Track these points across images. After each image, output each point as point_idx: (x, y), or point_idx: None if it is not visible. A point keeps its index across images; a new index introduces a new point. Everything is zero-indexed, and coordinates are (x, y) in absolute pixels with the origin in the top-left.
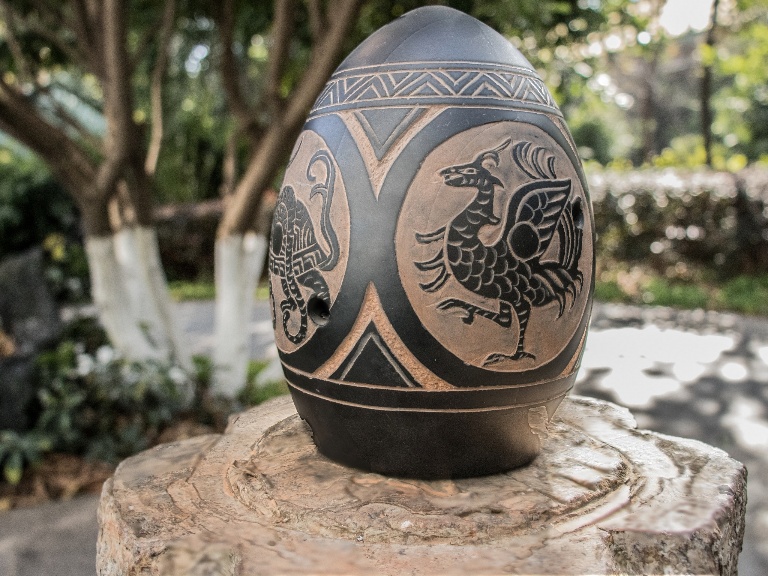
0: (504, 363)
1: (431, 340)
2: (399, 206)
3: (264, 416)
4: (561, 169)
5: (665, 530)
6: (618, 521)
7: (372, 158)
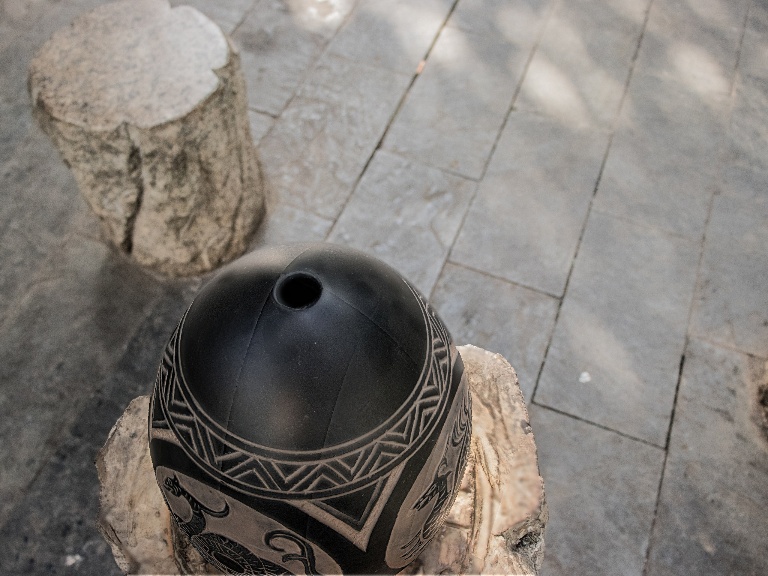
0: None
1: None
2: (385, 545)
3: (133, 509)
4: (466, 396)
5: (527, 514)
6: (500, 520)
7: (350, 530)
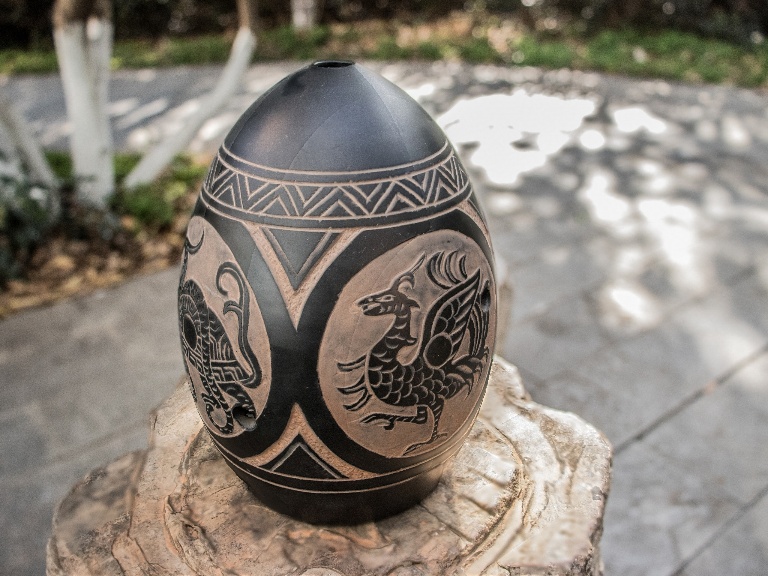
0: (421, 448)
1: (356, 447)
2: (319, 337)
3: (181, 413)
4: (471, 264)
5: (551, 563)
6: (514, 554)
7: (287, 285)
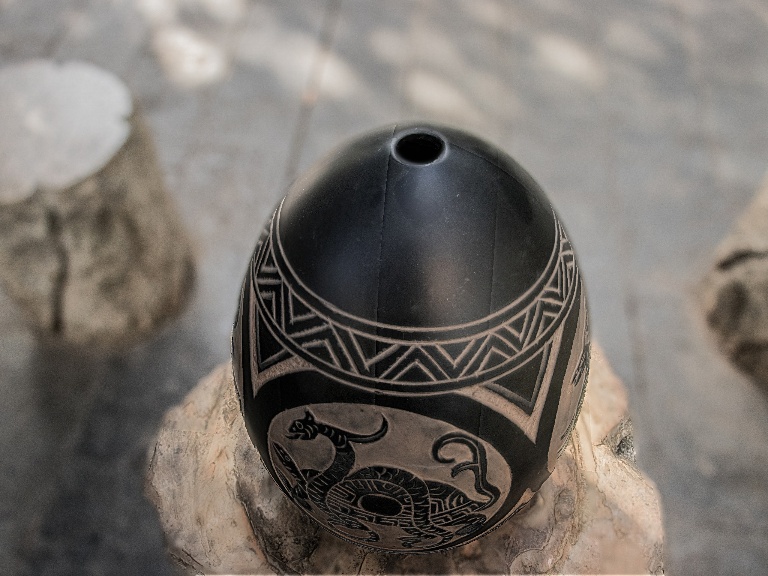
0: None
1: None
2: None
3: (204, 526)
4: None
5: (619, 416)
6: (595, 429)
7: (522, 416)
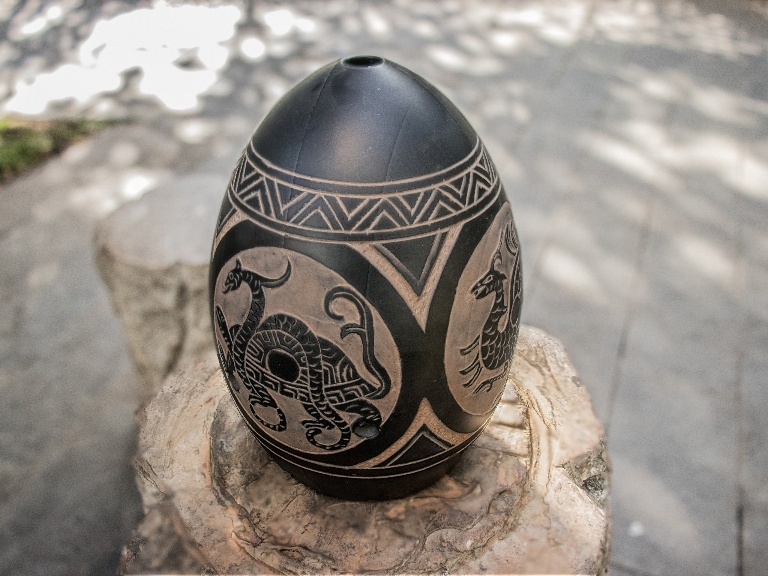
0: None
1: (467, 416)
2: (444, 332)
3: (172, 448)
4: None
5: (588, 448)
6: (559, 453)
7: (410, 294)
